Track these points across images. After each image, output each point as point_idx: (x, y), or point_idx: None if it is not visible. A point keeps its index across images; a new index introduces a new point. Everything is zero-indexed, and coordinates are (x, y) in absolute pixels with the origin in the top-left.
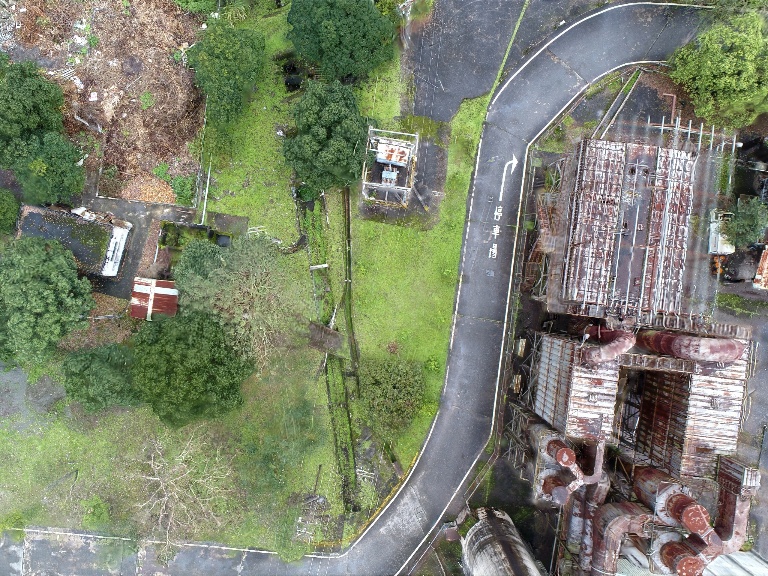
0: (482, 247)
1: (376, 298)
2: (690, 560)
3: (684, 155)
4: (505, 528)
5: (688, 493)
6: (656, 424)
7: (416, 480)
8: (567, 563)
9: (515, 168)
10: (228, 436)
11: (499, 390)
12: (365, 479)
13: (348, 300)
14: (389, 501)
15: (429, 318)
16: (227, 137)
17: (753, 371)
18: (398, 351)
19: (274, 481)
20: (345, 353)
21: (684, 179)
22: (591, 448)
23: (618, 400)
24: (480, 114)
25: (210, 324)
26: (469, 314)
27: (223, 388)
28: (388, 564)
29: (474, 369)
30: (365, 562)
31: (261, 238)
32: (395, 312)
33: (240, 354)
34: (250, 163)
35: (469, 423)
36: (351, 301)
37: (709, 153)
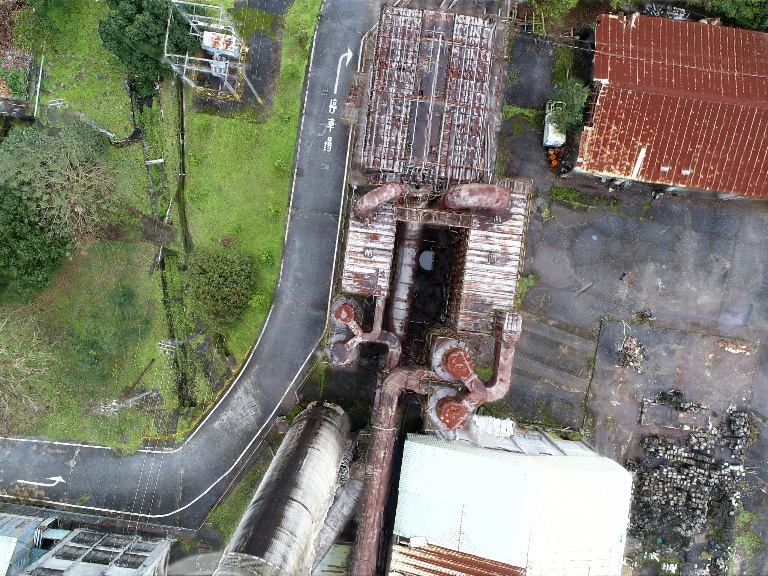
0: (317, 140)
1: (210, 191)
2: (453, 407)
3: (481, 22)
4: (324, 412)
5: (464, 348)
6: (454, 293)
7: (250, 374)
8: (363, 432)
9: (350, 61)
10: (60, 330)
11: (334, 284)
12: (166, 353)
13: (182, 194)
14: (222, 395)
15: (263, 211)
16: (48, 22)
17: (527, 224)
18: (231, 244)
19: (95, 368)
20: (178, 247)
21: (481, 46)
22: (371, 306)
23: (429, 277)
24: (315, 6)
25: (12, 198)
26: (304, 207)
27: (27, 264)
28: (222, 459)
29: (309, 263)
30: (199, 457)
31: (87, 127)
32: (229, 205)
33: (47, 231)
34: (82, 56)
35: (304, 317)
36: (184, 194)
37: (546, 46)
